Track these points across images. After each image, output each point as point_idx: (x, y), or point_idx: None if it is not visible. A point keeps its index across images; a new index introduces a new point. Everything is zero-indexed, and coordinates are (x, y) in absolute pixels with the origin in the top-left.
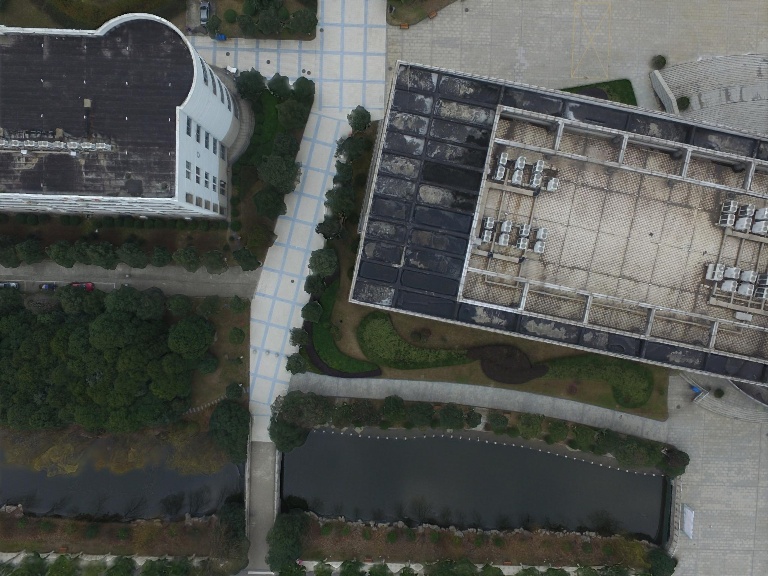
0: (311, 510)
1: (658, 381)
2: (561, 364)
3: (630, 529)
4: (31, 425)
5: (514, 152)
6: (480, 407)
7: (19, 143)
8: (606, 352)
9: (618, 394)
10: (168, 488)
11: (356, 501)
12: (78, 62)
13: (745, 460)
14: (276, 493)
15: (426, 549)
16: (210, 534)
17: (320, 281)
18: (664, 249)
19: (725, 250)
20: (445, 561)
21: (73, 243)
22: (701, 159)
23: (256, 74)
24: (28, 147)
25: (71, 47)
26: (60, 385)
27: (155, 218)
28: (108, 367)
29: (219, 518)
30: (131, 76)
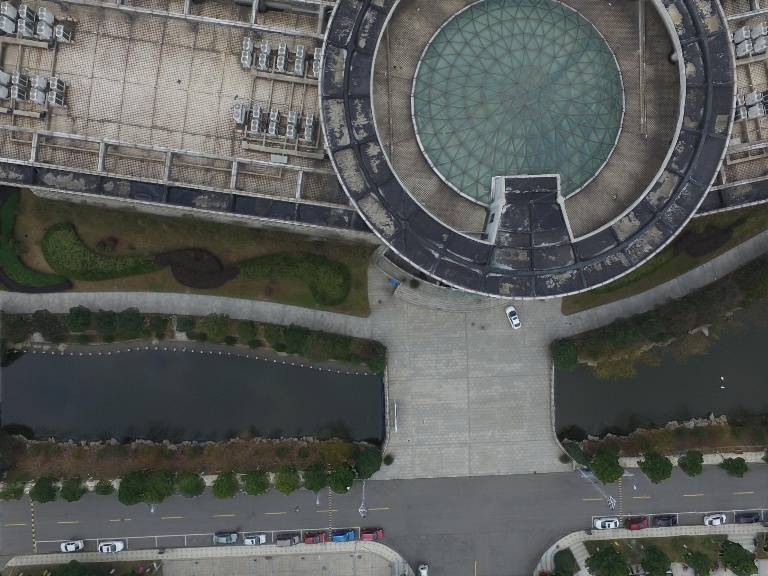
0: (20, 433)
1: (356, 276)
2: (252, 264)
3: (364, 435)
4: None
5: (30, 6)
6: None
7: None
8: (115, 197)
9: (314, 292)
10: None
11: (88, 427)
12: None
13: (452, 351)
14: None
15: (137, 464)
16: None
17: None
18: (194, 96)
19: (257, 93)
20: (139, 470)
21: None
22: (224, 1)
23: None
24: None
25: None
26: None
27: None
28: None
29: None
30: None
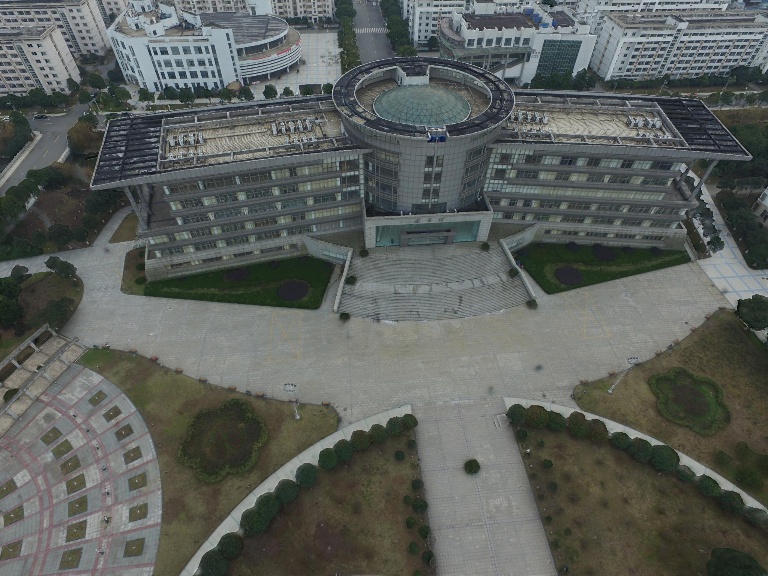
0: None
1: None
2: None
3: None
4: None
5: None
6: None
7: None
8: None
9: None
10: None
11: None
12: None
13: None
14: None
15: None
16: None
17: None
18: None
19: None
20: None
21: None
22: None
23: None
24: None
25: None
26: None
27: None
28: (760, 139)
29: None
30: None
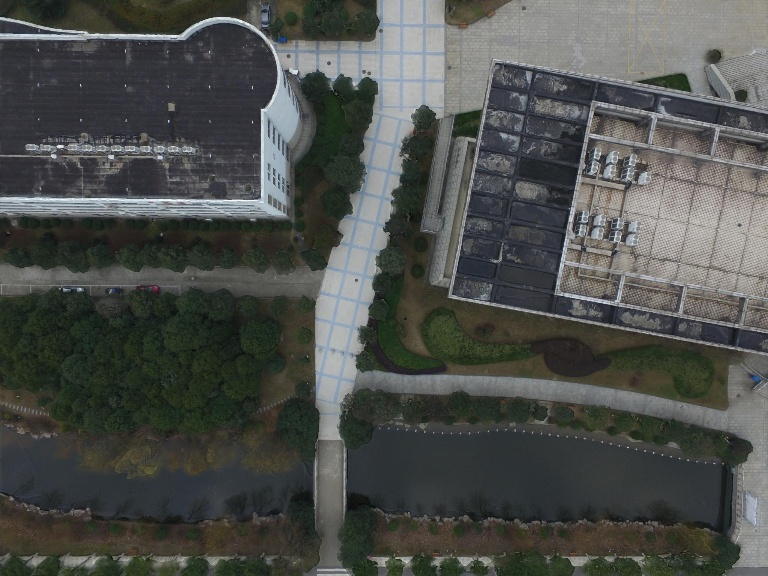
0: None
1: (718, 371)
2: (623, 356)
3: (689, 518)
4: (107, 428)
5: (604, 147)
6: (543, 400)
7: (106, 148)
8: (703, 341)
9: (679, 384)
10: (231, 488)
11: (417, 497)
12: (161, 67)
13: None
14: (344, 490)
15: (492, 542)
16: (279, 533)
17: (389, 279)
18: (752, 239)
19: None
20: (515, 553)
21: (141, 247)
22: None
23: (321, 75)
24: (115, 152)
25: (154, 52)
26: (134, 388)
27: (219, 220)
28: (183, 369)
29: (289, 516)
30: (213, 80)
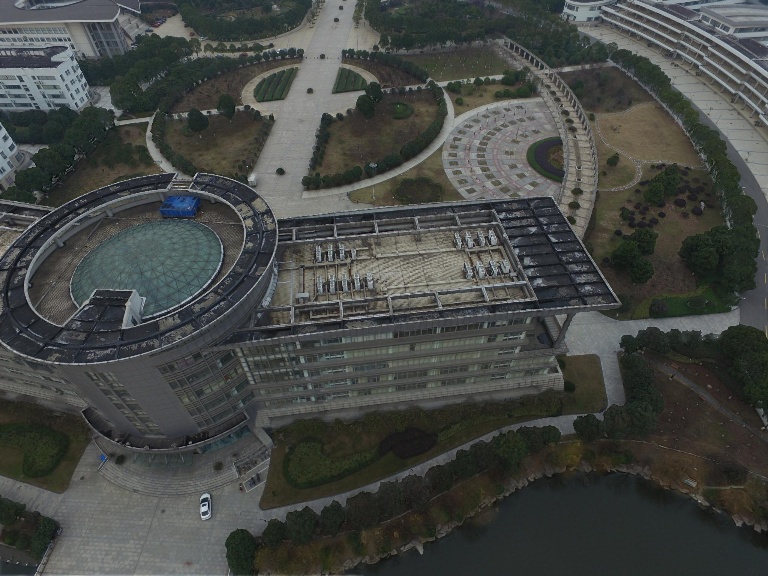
0: None
1: (73, 451)
2: None
3: None
4: None
5: None
6: None
7: None
8: None
9: (25, 461)
10: None
11: None
12: None
13: (129, 542)
14: None
15: None
16: None
17: None
18: None
19: None
20: None
21: None
22: (26, 226)
23: None
24: None
25: None
26: None
27: None
28: None
29: None
30: None
